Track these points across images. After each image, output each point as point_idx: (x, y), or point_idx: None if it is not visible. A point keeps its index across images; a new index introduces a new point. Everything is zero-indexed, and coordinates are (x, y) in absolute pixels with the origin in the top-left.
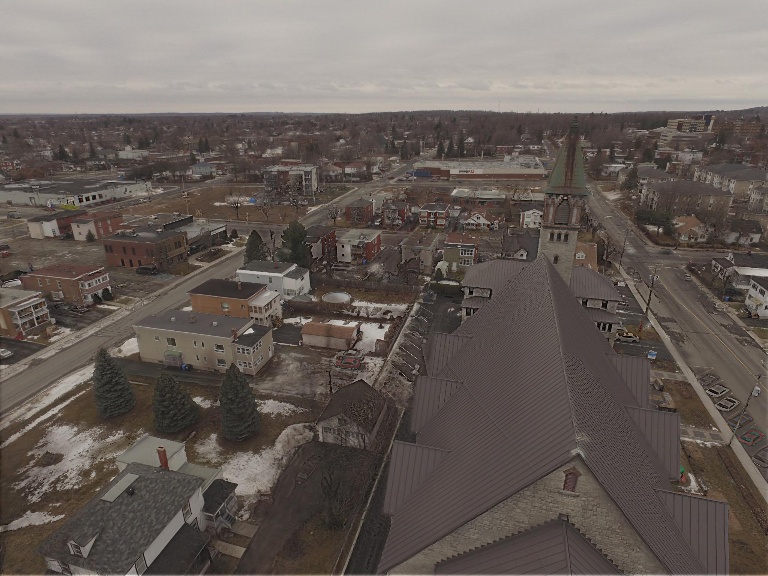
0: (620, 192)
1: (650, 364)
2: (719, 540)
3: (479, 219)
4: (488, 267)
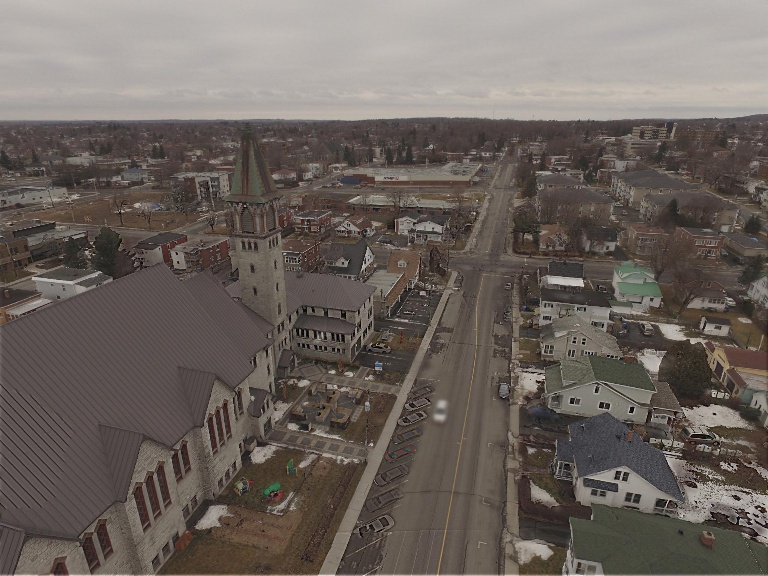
0: (525, 199)
1: (375, 376)
2: (5, 571)
3: (350, 226)
4: None
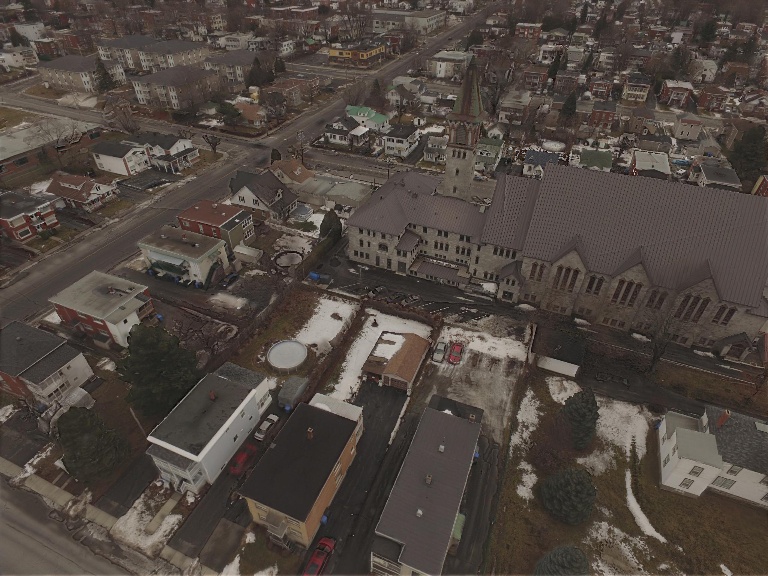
0: (90, 95)
1: None
2: None
3: (100, 189)
4: (388, 209)
